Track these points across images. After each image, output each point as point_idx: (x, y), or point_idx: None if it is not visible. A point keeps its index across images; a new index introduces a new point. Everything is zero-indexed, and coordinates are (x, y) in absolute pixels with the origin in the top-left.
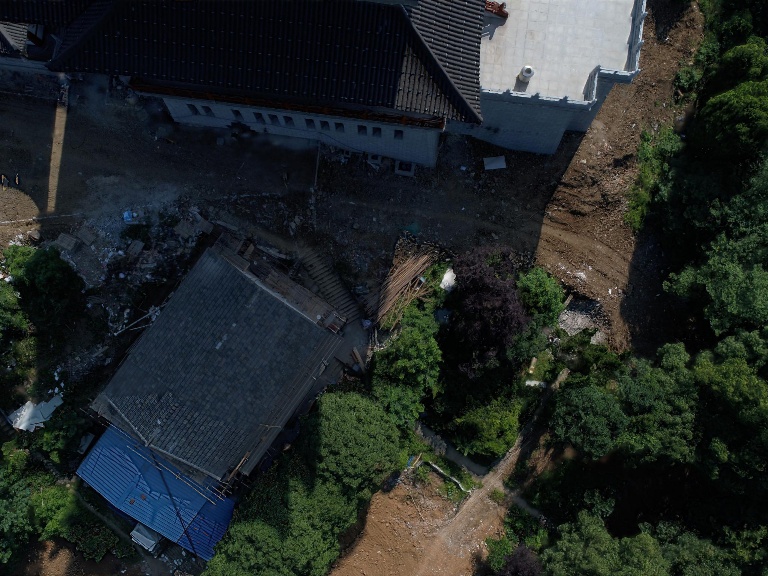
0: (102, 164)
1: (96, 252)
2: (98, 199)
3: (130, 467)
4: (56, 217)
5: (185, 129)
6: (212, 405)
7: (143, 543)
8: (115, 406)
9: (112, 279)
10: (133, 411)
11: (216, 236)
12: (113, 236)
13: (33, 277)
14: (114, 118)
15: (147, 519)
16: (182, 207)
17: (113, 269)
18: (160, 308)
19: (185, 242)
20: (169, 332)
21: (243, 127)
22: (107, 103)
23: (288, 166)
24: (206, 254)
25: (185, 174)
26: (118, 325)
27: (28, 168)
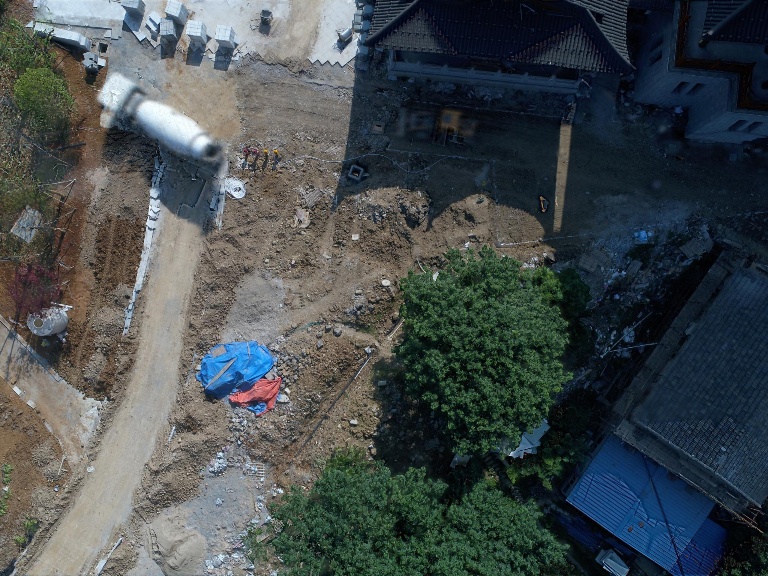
0: (609, 183)
1: (604, 273)
2: (606, 219)
3: (627, 494)
4: (562, 238)
5: (695, 145)
6: (767, 430)
7: (617, 571)
8: (656, 432)
9: (605, 300)
10: (682, 437)
11: (716, 254)
12: (617, 256)
13: (567, 301)
14: (622, 136)
15: (643, 547)
16: (693, 225)
17: (611, 290)
18: (633, 329)
19: (679, 261)
20: (709, 355)
21: (762, 142)
22: (614, 120)
23: None
24: (739, 274)
25: (697, 191)
26: (603, 347)
27: (532, 188)
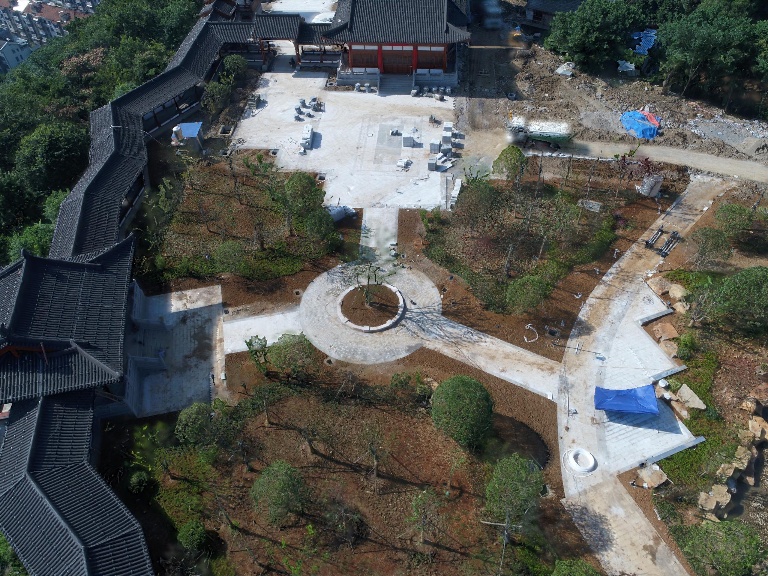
0: None
1: None
2: None
3: None
4: None
5: None
6: None
7: None
8: None
9: None
10: None
11: None
12: None
13: None
14: (473, 35)
15: None
16: (508, 22)
17: None
18: None
19: None
20: (566, 8)
21: None
22: None
23: (482, 4)
24: (528, 6)
25: None
26: None
27: None
